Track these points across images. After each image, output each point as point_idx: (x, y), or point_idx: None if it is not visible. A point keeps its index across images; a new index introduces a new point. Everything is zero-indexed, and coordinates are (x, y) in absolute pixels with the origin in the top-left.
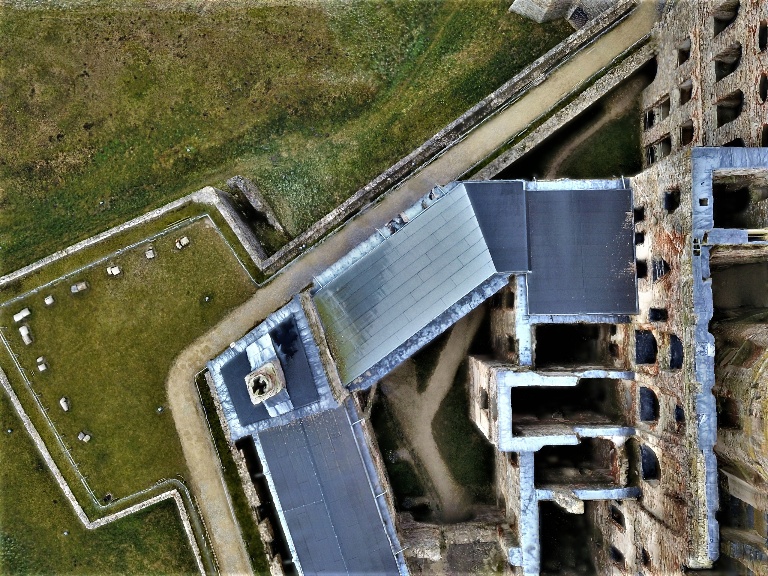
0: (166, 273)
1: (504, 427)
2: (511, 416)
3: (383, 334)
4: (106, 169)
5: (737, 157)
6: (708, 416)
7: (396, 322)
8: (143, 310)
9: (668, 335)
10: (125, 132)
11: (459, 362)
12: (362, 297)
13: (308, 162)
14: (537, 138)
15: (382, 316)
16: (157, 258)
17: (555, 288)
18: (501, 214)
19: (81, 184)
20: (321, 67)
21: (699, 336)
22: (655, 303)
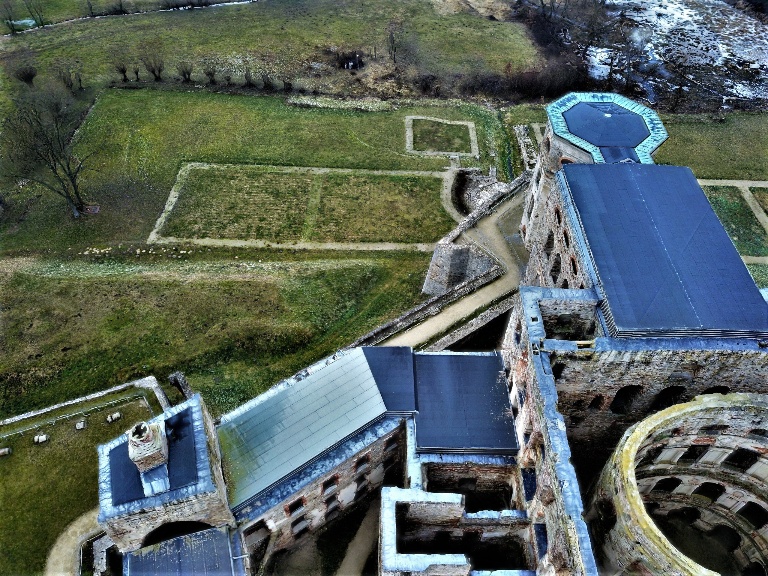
0: (89, 442)
1: (388, 542)
2: (395, 531)
3: (277, 461)
4: (68, 382)
5: (555, 293)
6: (569, 482)
7: (291, 450)
8: (54, 475)
9: (538, 446)
10: (95, 354)
11: (368, 554)
12: (263, 429)
13: (246, 383)
14: (435, 349)
15: (279, 445)
16: (85, 430)
17: (440, 426)
18: (392, 368)
19: (40, 394)
20: (269, 317)
21: (548, 414)
22: (525, 423)
